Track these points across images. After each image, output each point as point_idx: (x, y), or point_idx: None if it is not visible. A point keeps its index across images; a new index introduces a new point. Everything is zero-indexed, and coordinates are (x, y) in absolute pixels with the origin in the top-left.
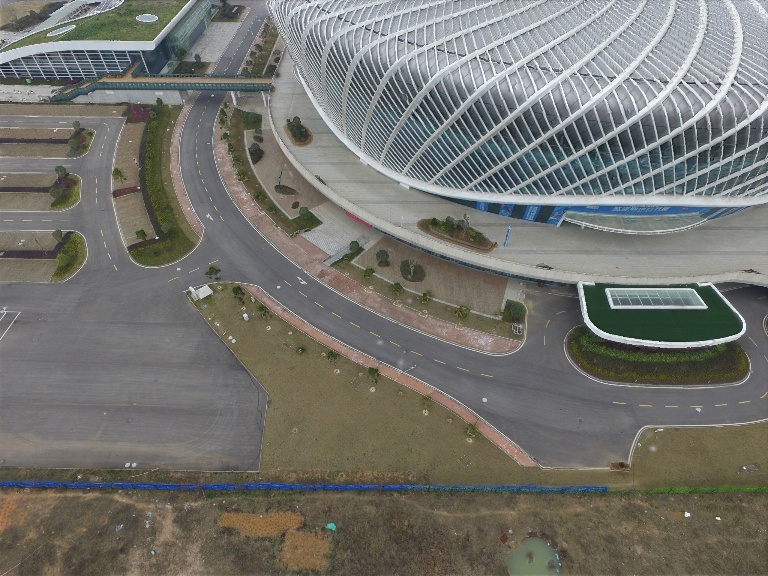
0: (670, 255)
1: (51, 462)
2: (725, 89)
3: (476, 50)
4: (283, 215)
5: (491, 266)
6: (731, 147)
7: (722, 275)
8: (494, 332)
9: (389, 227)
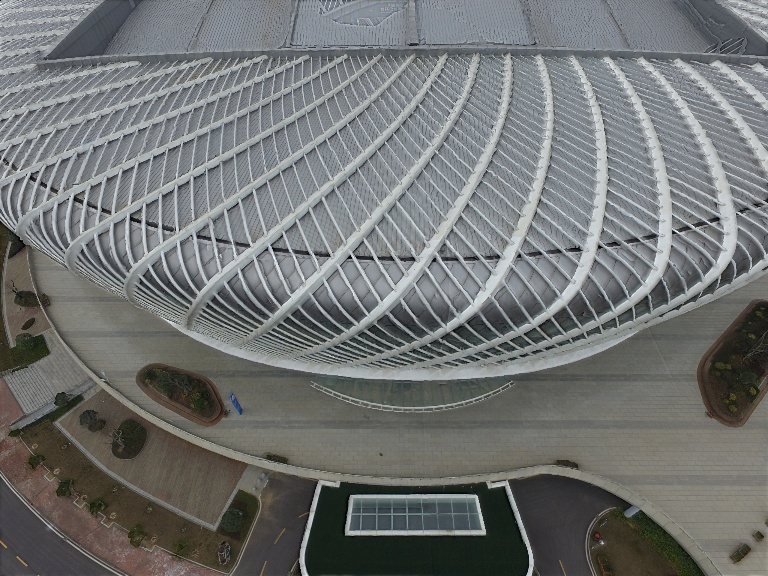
0: (464, 429)
1: None
2: (414, 272)
3: (74, 185)
4: (3, 341)
5: (208, 449)
6: (460, 343)
7: (523, 471)
8: (194, 555)
9: (96, 380)
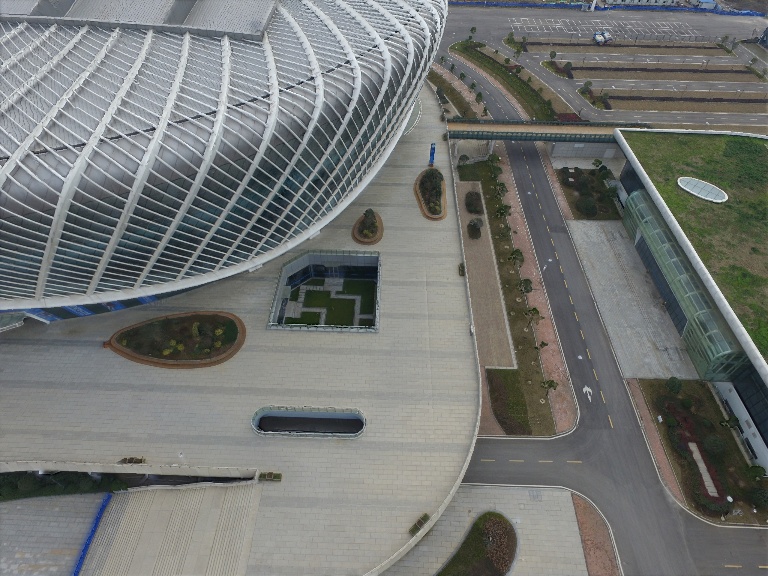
0: None
1: (460, 7)
2: None
3: None
4: None
5: None
6: None
7: None
8: None
9: None
